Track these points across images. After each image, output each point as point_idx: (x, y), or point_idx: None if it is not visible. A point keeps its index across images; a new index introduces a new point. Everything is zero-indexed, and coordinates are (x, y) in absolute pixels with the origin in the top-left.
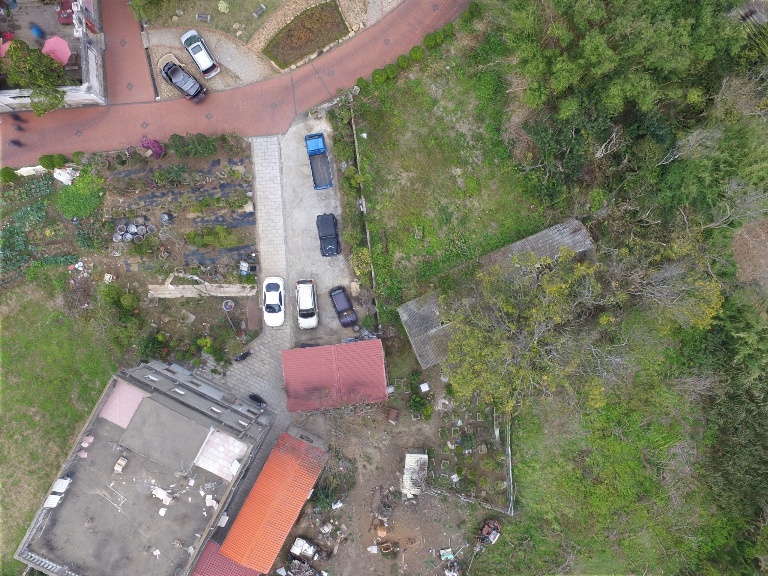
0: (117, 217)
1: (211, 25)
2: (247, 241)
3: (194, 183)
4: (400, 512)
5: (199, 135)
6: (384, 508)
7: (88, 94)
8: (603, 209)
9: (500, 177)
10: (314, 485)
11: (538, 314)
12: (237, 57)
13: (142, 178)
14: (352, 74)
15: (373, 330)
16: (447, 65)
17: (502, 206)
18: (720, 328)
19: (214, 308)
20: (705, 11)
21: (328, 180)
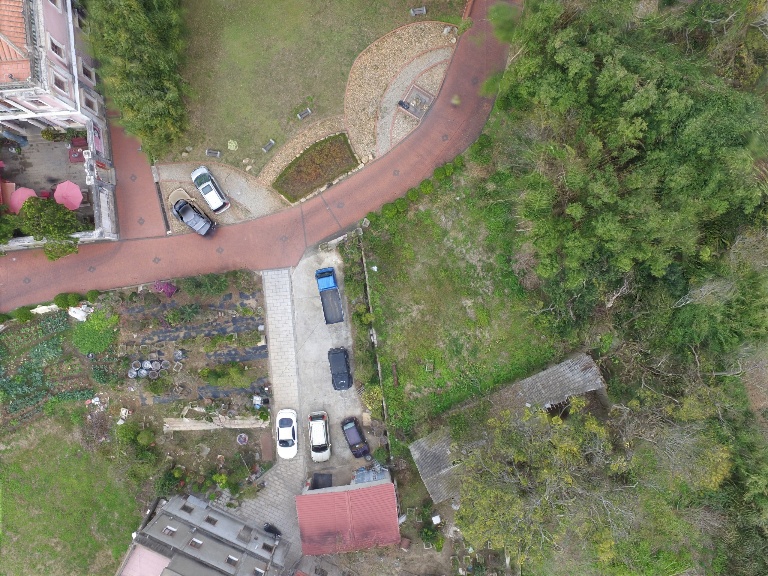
0: (132, 353)
1: (221, 160)
2: (260, 374)
3: (207, 318)
4: None
5: (211, 276)
6: None
7: None
8: (614, 340)
9: (510, 309)
10: None
11: (549, 474)
12: (247, 191)
13: (155, 313)
14: (362, 206)
15: (385, 463)
16: (457, 196)
17: (512, 336)
18: (730, 462)
19: (228, 440)
20: (719, 170)
21: (339, 314)
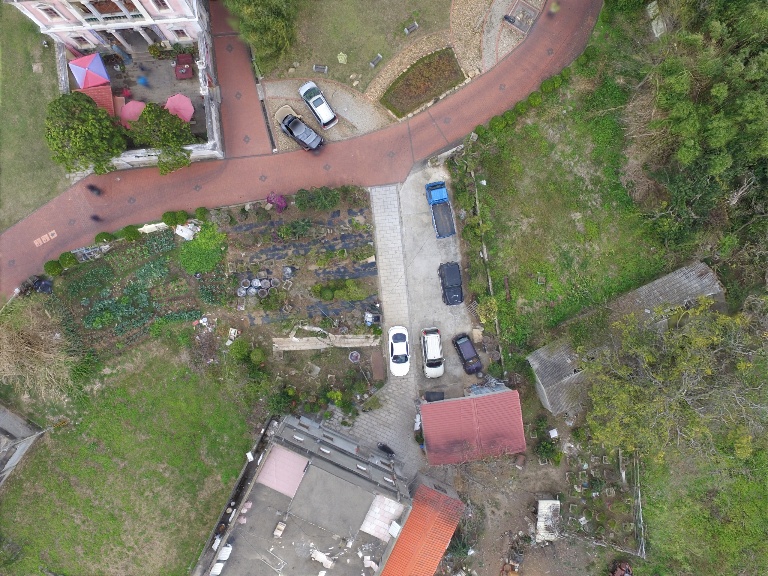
0: (240, 272)
1: (327, 76)
2: (369, 291)
3: (316, 235)
4: (529, 556)
5: (324, 189)
6: (517, 554)
7: (212, 151)
8: None
9: (620, 220)
10: (452, 536)
11: (688, 366)
12: (354, 107)
13: (263, 231)
14: (469, 120)
15: (500, 377)
16: (564, 109)
17: (622, 249)
18: None
19: (339, 359)
20: None
21: (450, 228)
